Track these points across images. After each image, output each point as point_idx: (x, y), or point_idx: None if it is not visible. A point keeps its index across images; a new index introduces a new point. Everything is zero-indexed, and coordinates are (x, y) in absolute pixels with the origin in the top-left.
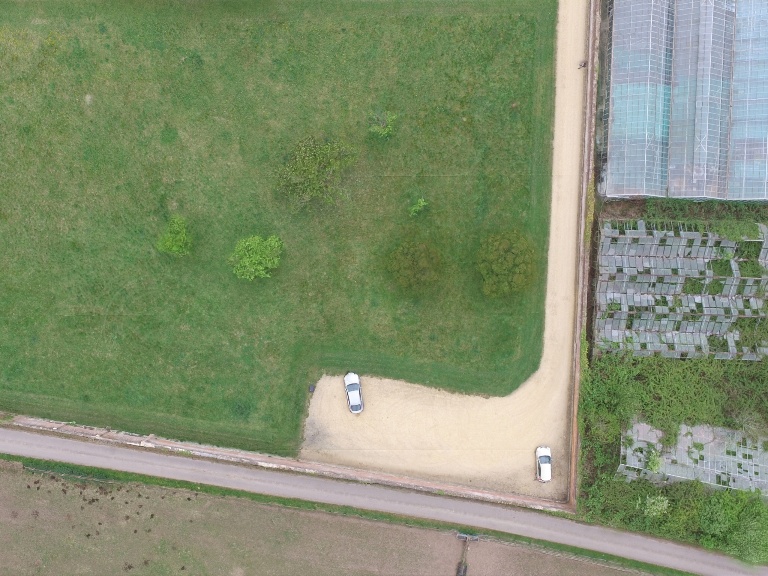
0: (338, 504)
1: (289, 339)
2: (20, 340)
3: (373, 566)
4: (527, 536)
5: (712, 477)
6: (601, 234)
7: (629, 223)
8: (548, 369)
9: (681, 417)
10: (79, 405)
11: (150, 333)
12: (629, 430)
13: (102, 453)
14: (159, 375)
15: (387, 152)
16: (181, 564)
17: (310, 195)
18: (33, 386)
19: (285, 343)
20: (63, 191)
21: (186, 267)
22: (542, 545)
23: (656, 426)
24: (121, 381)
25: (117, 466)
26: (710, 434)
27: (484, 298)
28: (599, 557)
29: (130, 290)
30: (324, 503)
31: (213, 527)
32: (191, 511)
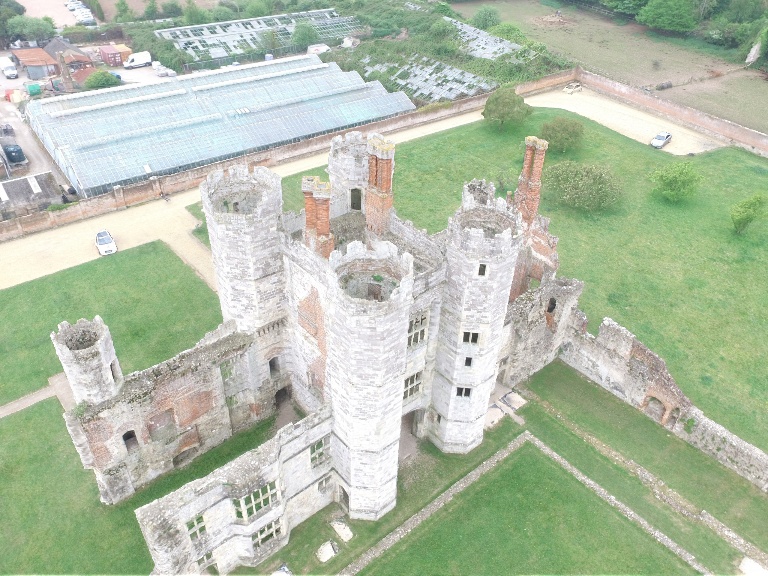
0: None
1: None
2: None
3: (717, 105)
4: None
5: None
6: None
7: None
8: None
9: None
10: None
11: None
12: None
13: None
14: None
15: None
16: None
17: None
18: None
19: None
20: None
21: (749, 226)
22: None
23: None
24: None
25: None
26: None
27: None
28: None
29: None
30: None
31: None
32: None
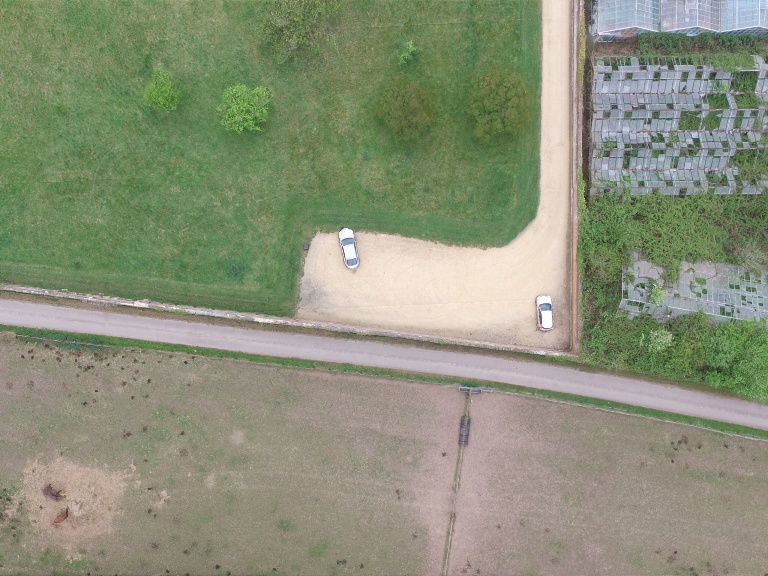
0: (337, 362)
1: (281, 197)
2: (8, 209)
3: (375, 423)
4: (530, 387)
5: (716, 309)
6: (594, 70)
7: (622, 60)
8: (545, 217)
9: (682, 253)
10: (71, 273)
11: (140, 196)
12: (630, 268)
13: (96, 319)
14: (151, 239)
15: (373, 2)
16: (180, 429)
17: (296, 41)
18: (23, 255)
19: (277, 201)
20: (46, 55)
21: (174, 127)
22: (546, 395)
23: (657, 263)
24: (112, 246)
25: (111, 332)
26: (712, 270)
27: (478, 147)
28: (604, 405)
29: (118, 153)
30: (323, 361)
31: (211, 390)
32: (188, 375)
